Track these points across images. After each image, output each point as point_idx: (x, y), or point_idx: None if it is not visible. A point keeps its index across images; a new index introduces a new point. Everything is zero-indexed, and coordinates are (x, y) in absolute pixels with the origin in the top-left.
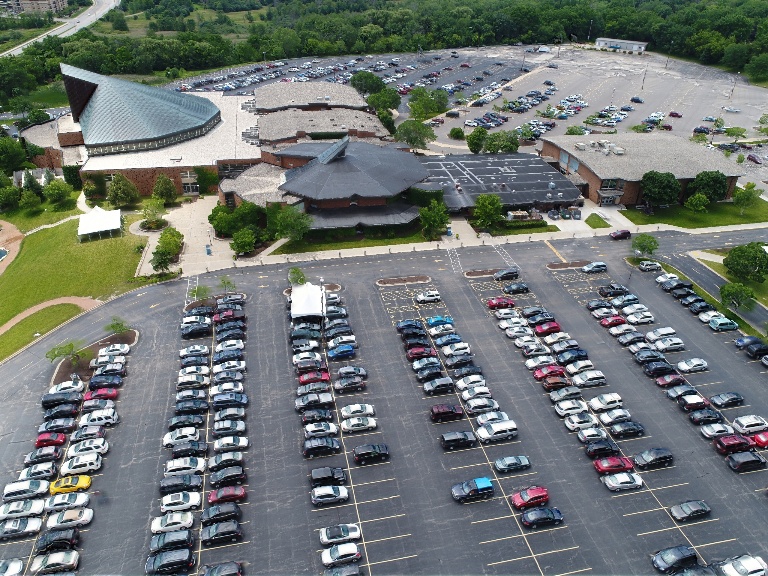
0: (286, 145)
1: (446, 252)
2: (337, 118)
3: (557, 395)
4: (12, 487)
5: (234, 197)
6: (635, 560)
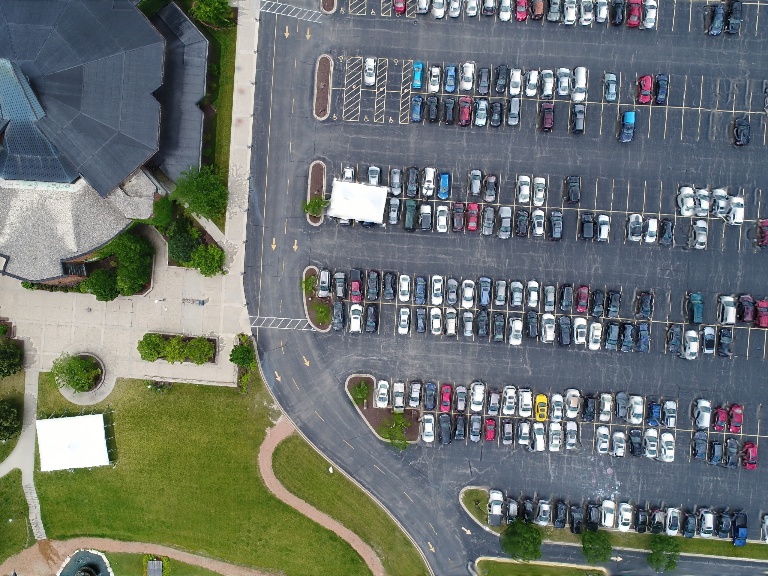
0: None
1: (269, 14)
2: None
3: (555, 15)
4: (540, 446)
5: (68, 262)
6: (705, 45)
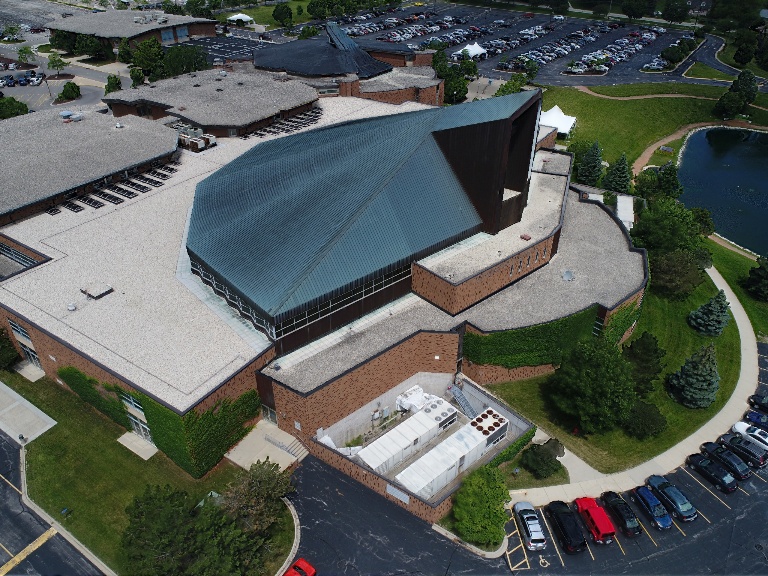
0: (318, 82)
1: None
2: (183, 87)
3: (429, 30)
4: None
5: None
6: None
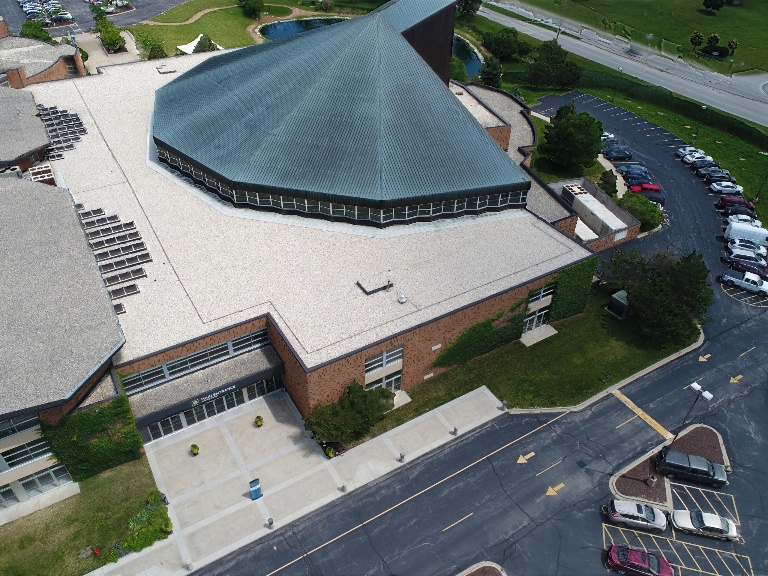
0: None
1: None
2: None
3: None
4: None
5: None
6: None
